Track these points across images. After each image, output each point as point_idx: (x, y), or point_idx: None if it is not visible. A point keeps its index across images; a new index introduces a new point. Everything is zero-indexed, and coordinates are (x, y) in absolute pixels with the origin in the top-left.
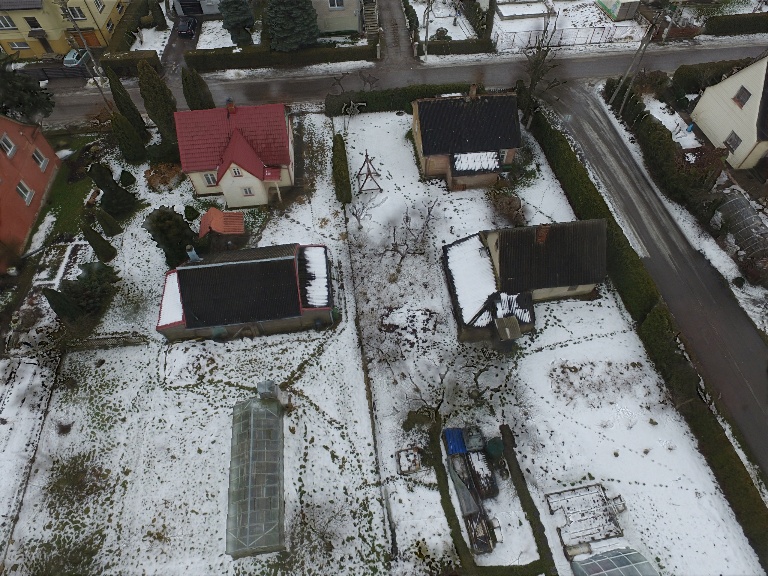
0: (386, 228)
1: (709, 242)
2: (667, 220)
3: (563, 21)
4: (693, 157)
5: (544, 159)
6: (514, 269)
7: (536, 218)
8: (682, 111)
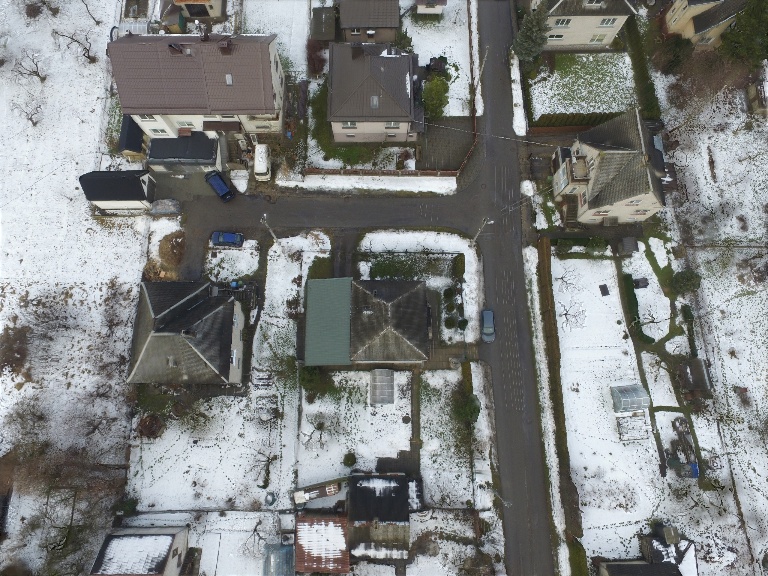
0: None
1: None
2: None
3: None
4: None
5: None
6: None
7: None
8: None
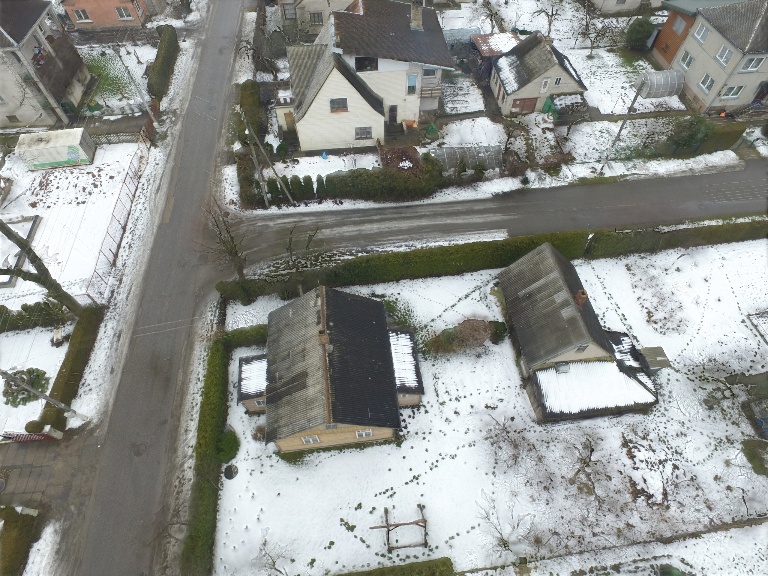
0: (512, 497)
1: (484, 186)
2: (457, 206)
3: (62, 213)
4: (406, 162)
5: (363, 288)
6: (601, 338)
7: (463, 312)
8: (291, 154)
